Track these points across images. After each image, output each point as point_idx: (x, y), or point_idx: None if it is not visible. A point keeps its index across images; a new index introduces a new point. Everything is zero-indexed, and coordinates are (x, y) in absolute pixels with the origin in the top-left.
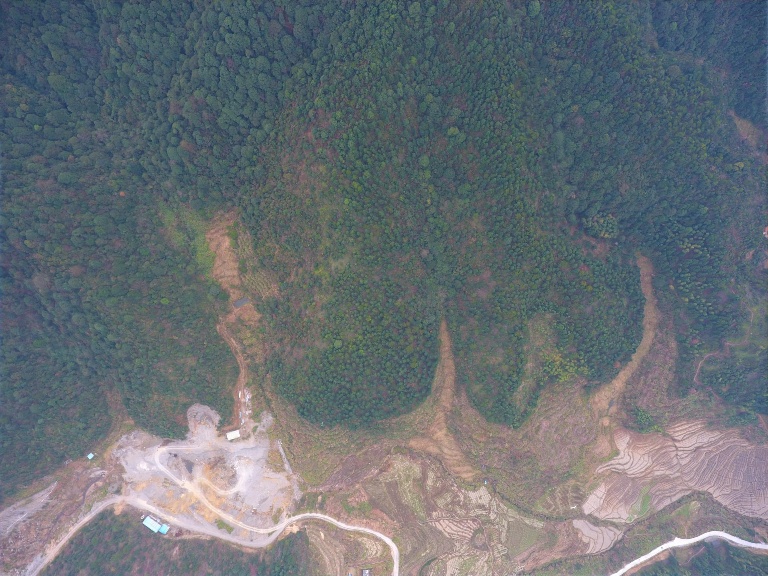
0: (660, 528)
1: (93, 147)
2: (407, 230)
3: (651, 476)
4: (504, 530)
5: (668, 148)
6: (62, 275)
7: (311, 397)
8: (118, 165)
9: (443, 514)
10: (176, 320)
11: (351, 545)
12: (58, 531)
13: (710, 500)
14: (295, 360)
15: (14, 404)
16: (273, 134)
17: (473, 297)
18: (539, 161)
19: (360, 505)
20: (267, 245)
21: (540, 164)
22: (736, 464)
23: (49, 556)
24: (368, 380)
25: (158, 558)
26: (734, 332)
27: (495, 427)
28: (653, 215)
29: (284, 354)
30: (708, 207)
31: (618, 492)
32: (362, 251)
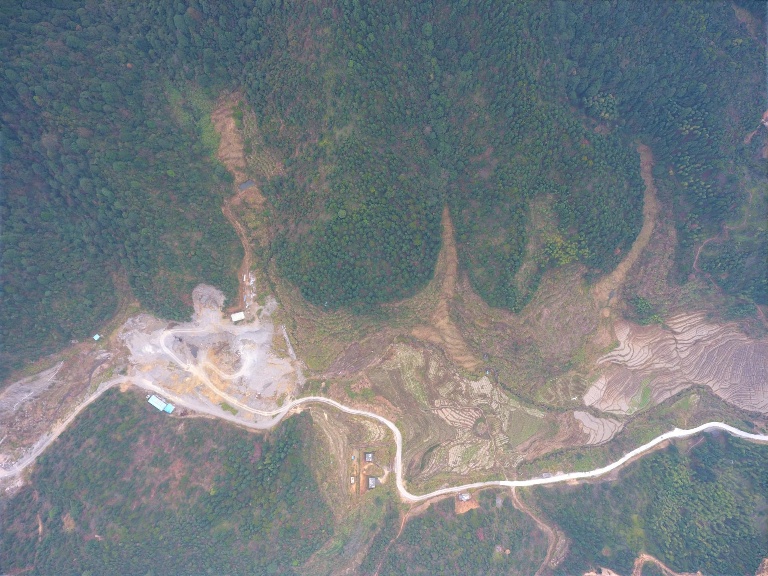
0: (660, 419)
1: (100, 20)
2: (410, 102)
3: (651, 369)
4: (506, 419)
5: (667, 18)
6: (70, 135)
7: (315, 274)
8: (125, 40)
9: (445, 402)
10: (182, 194)
11: (354, 427)
12: (64, 411)
13: (709, 394)
14: (299, 235)
15: (22, 273)
16: (278, 1)
17: (475, 178)
18: (541, 26)
19: (363, 391)
20: (272, 121)
21: (542, 29)
22: (735, 358)
23: (55, 434)
24: (372, 254)
25: (163, 432)
26: (733, 214)
27: (497, 312)
28: (653, 96)
29: (288, 233)
30: (707, 85)
31: (618, 384)
32: (366, 119)
